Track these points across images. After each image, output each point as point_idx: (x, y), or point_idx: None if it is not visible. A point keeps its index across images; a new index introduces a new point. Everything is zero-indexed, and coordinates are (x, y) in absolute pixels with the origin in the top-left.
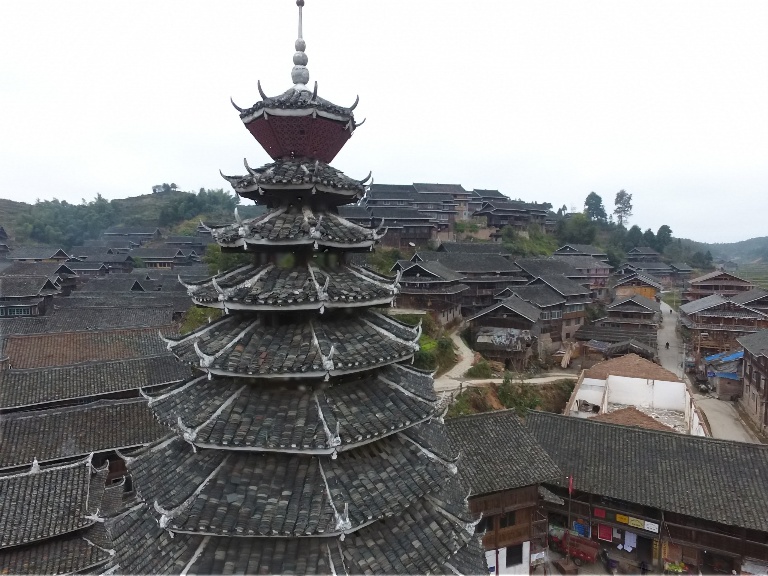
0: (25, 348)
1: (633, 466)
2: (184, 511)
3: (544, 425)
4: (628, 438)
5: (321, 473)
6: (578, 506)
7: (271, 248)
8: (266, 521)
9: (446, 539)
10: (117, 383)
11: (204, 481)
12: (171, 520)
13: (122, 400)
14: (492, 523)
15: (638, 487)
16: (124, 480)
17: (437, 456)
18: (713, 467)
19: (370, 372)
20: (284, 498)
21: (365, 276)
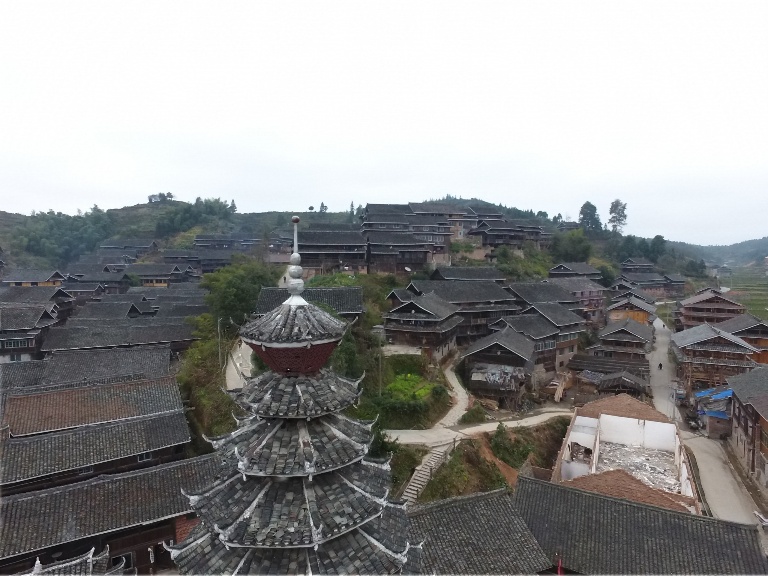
0: (24, 409)
1: (620, 543)
2: None
3: (535, 494)
4: (616, 511)
5: None
6: None
7: None
8: None
9: None
10: (116, 450)
11: None
12: None
13: (121, 474)
14: None
15: (625, 567)
16: (124, 561)
17: None
18: (697, 547)
19: None
20: None
21: (357, 486)
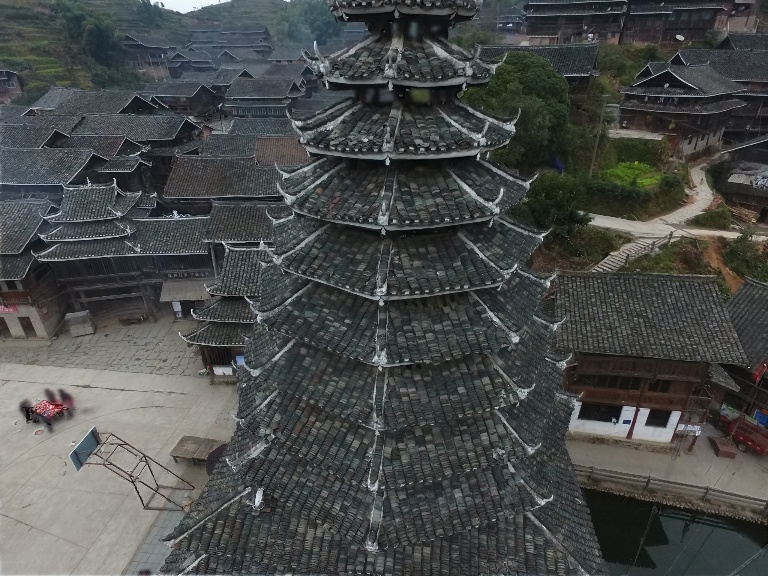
0: (267, 147)
1: None
2: (274, 315)
3: (763, 301)
4: None
5: (378, 312)
6: (767, 397)
7: (352, 87)
8: (326, 339)
9: (492, 394)
10: None
11: (292, 296)
12: (264, 319)
13: None
14: (639, 384)
15: None
16: None
17: (501, 322)
18: None
19: (448, 227)
20: (344, 325)
21: (454, 121)
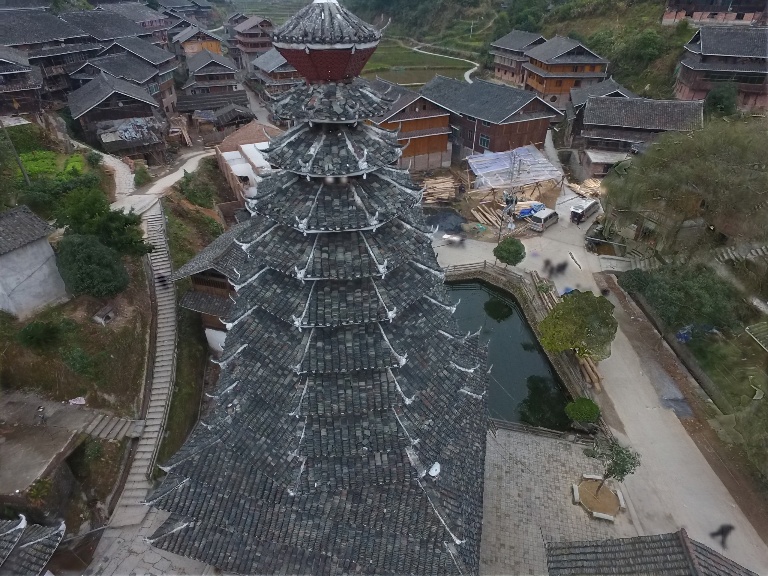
0: None
1: None
2: None
3: None
4: None
5: (423, 296)
6: None
7: None
8: (429, 330)
9: None
10: None
11: None
12: None
13: None
14: None
15: None
16: None
17: None
18: None
19: None
20: (423, 317)
21: (391, 168)
